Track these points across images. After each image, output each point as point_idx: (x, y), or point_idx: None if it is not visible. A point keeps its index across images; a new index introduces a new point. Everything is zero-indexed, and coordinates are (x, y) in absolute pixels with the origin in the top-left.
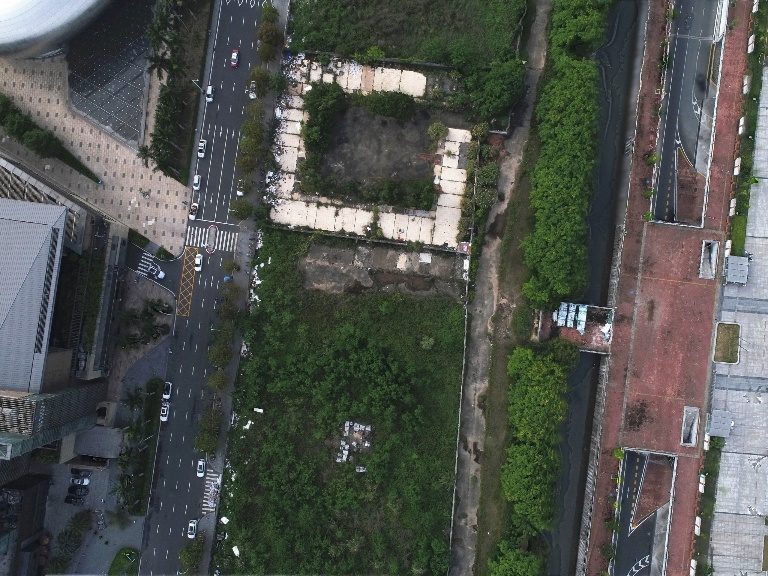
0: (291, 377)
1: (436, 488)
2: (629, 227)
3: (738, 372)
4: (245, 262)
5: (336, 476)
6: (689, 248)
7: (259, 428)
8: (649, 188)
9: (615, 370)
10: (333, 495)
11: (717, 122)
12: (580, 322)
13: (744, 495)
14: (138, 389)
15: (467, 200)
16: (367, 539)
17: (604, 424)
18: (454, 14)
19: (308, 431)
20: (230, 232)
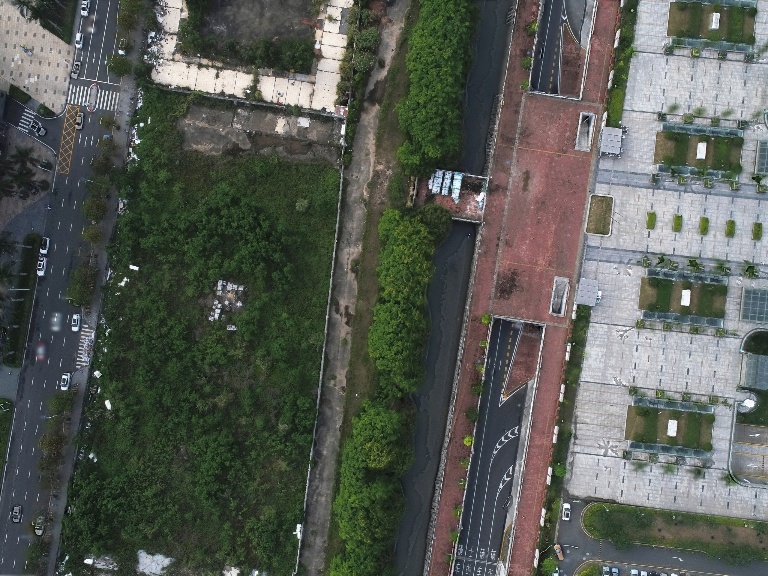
0: (165, 234)
1: (304, 346)
2: (508, 97)
3: (610, 244)
4: (125, 121)
5: (207, 333)
6: (566, 120)
7: (134, 285)
8: (529, 59)
9: (488, 239)
10: (203, 351)
11: None
12: (454, 190)
13: (610, 365)
14: (15, 242)
15: (345, 64)
16: (236, 396)
17: (475, 292)
18: None
19: (182, 289)
20: (111, 91)
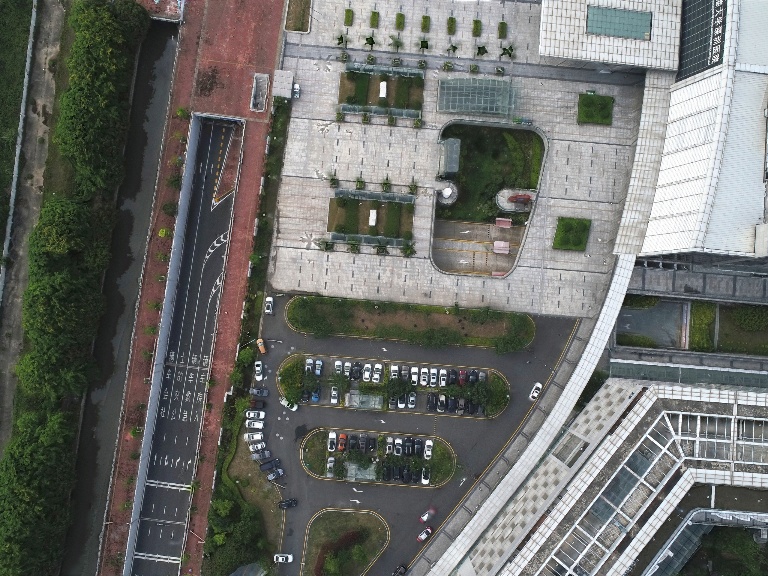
0: None
1: None
2: None
3: (309, 41)
4: None
5: None
6: None
7: None
8: None
9: (188, 38)
10: None
11: None
12: None
13: (311, 159)
14: None
15: None
16: None
17: (175, 89)
18: None
19: None
20: None
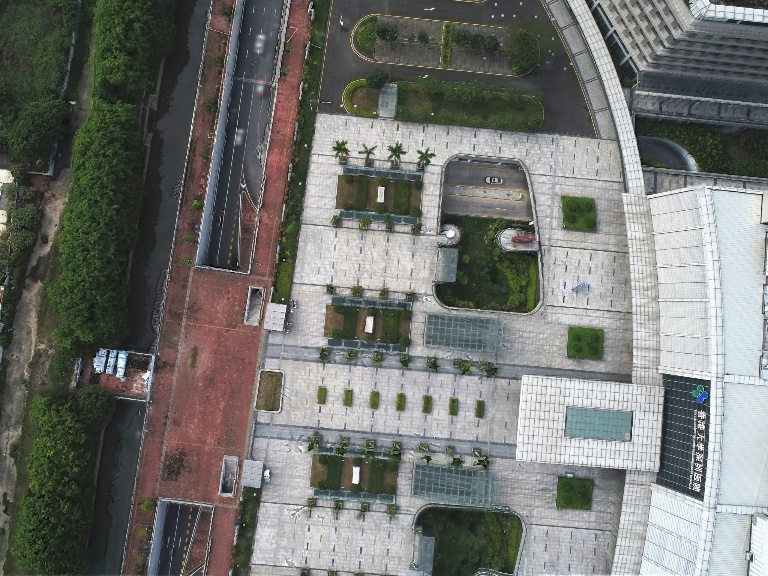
0: None
1: None
2: (175, 272)
3: (280, 420)
4: None
5: None
6: (235, 294)
7: None
8: (196, 233)
9: (155, 418)
10: None
11: (268, 168)
12: (118, 369)
13: (282, 546)
14: None
15: (1, 242)
16: None
17: (141, 474)
18: (1, 52)
19: None
20: None
